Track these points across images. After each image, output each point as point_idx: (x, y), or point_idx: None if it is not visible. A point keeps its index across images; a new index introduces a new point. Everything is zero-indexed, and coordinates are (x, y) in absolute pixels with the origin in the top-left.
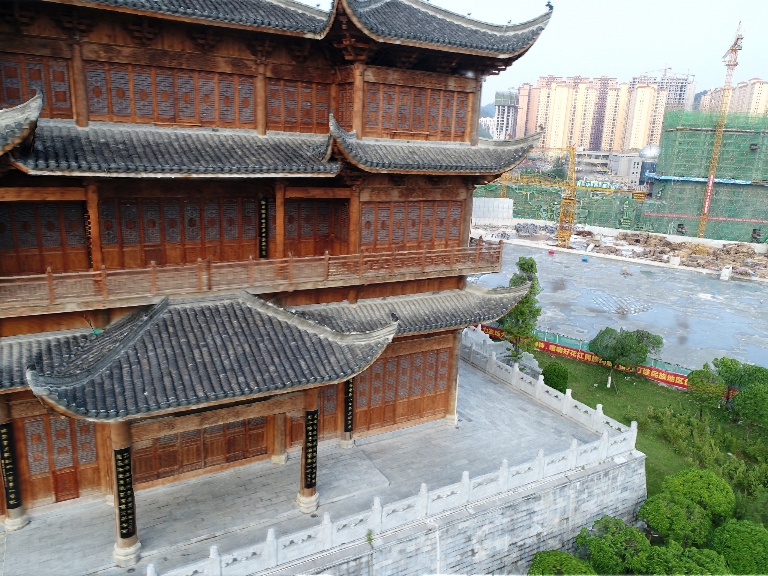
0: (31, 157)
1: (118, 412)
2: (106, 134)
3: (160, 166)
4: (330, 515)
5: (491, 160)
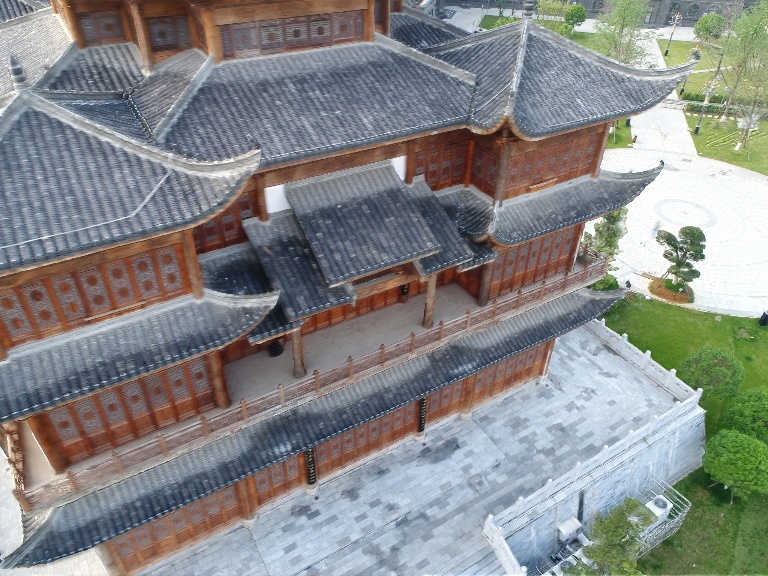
0: None
1: None
2: None
3: None
4: (3, 480)
5: None
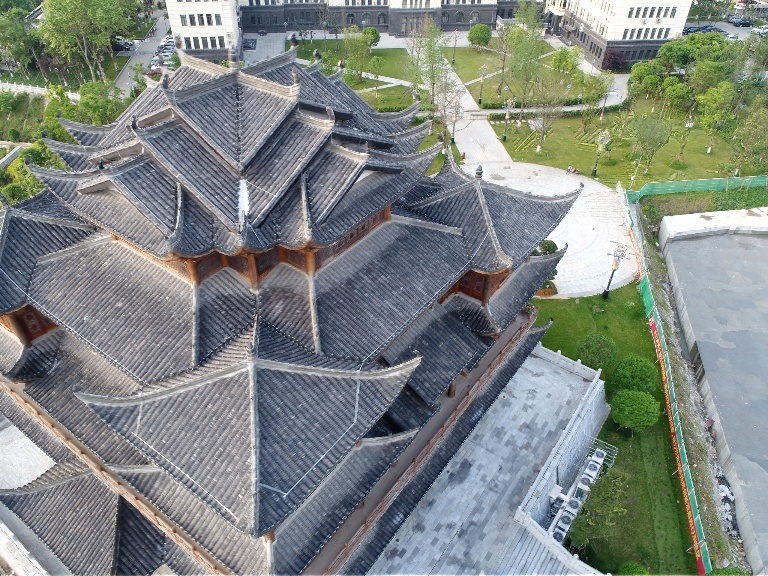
0: (33, 382)
1: (20, 518)
2: (96, 364)
3: (59, 422)
4: None
5: (254, 570)
